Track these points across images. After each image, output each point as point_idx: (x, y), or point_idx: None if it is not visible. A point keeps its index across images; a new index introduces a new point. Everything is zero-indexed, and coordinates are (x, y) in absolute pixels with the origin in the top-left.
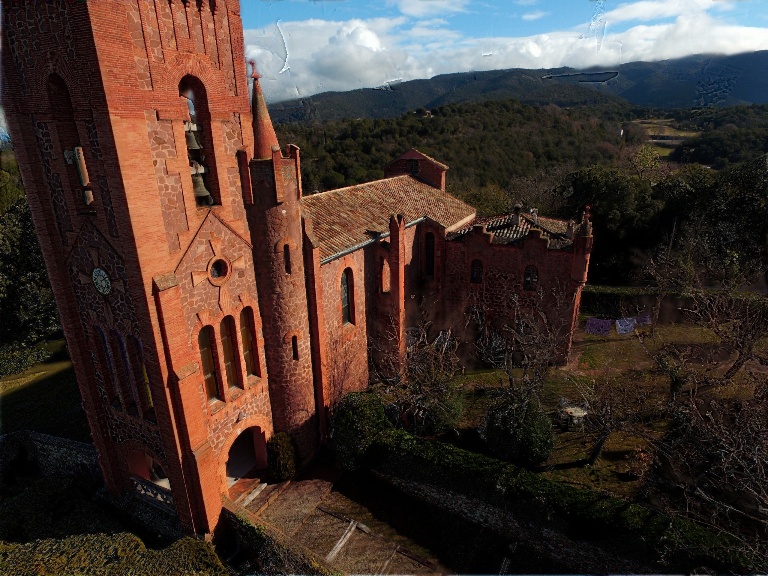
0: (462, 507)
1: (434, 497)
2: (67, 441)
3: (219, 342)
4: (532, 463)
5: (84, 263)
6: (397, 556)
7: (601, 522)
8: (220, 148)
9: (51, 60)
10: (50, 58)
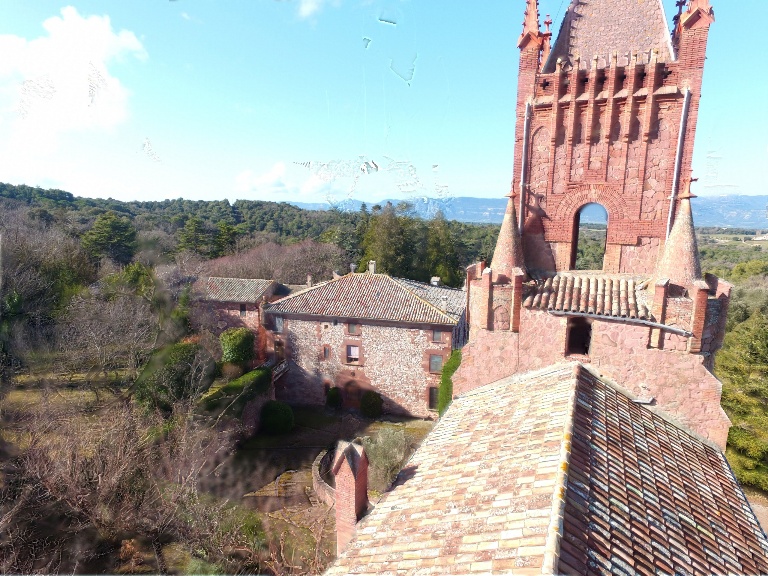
0: None
1: None
2: None
3: None
4: None
5: None
6: None
7: None
8: None
9: None
10: None
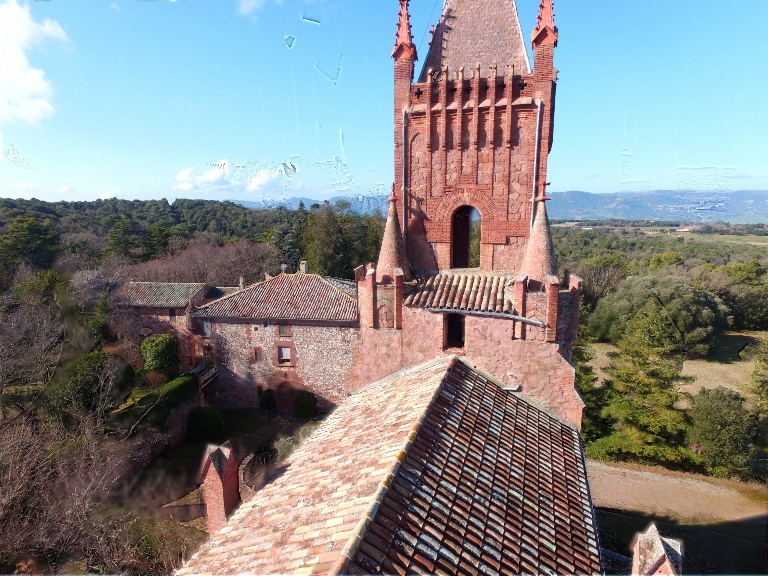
0: None
1: None
2: None
3: None
4: None
5: None
6: None
7: None
8: None
9: None
10: None
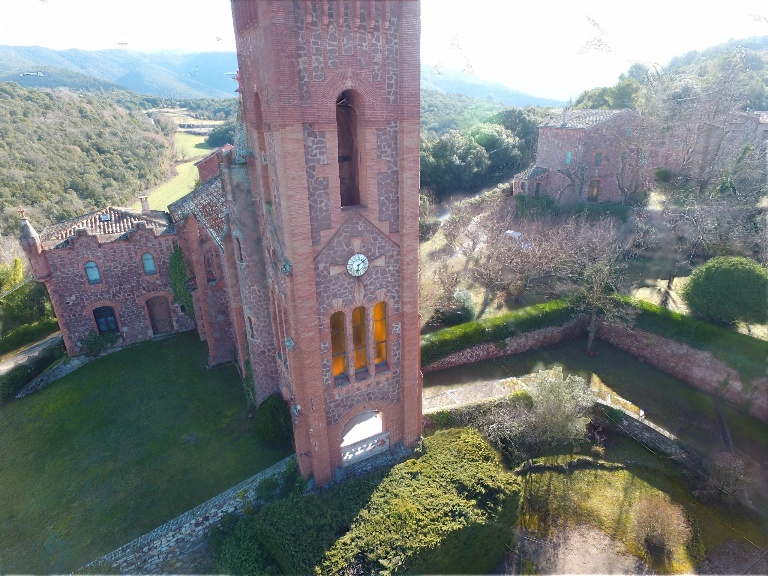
0: (467, 357)
1: (453, 362)
2: (188, 513)
3: None
4: (472, 320)
5: (338, 255)
6: (476, 390)
7: (527, 319)
8: None
9: (351, 79)
10: (350, 77)
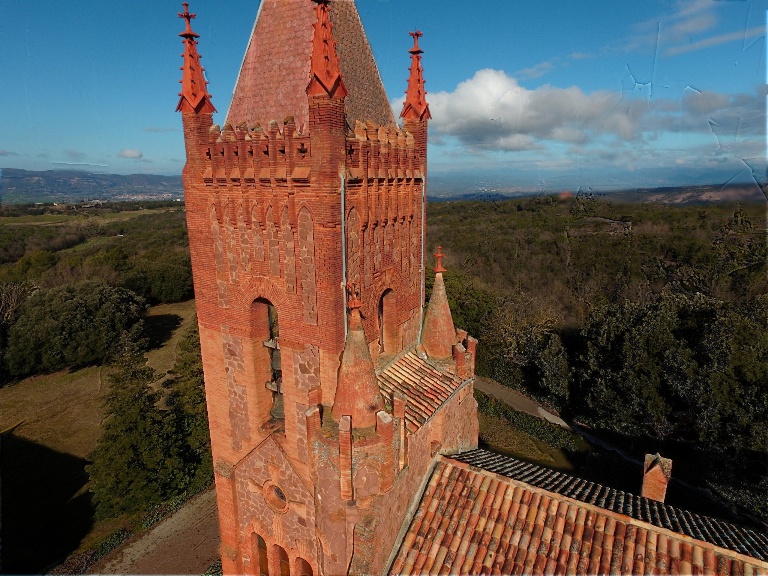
0: None
1: None
2: None
3: (271, 561)
4: None
5: None
6: None
7: None
8: (289, 378)
9: None
10: None
